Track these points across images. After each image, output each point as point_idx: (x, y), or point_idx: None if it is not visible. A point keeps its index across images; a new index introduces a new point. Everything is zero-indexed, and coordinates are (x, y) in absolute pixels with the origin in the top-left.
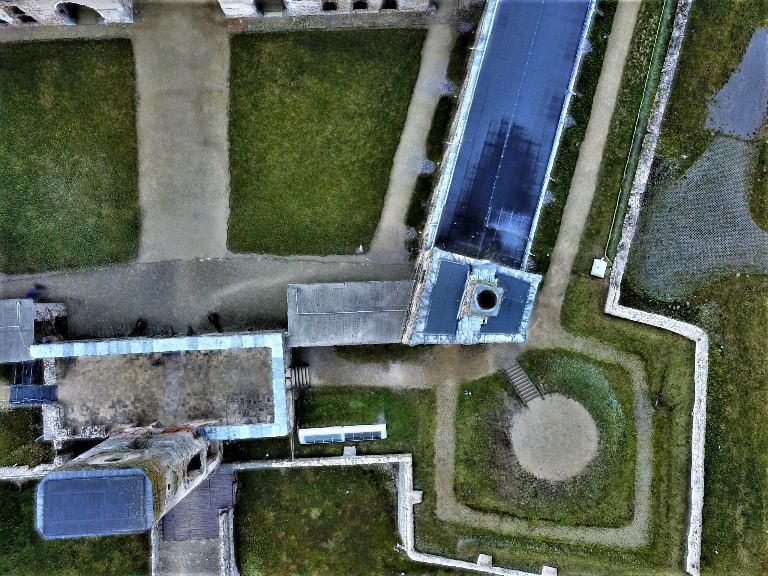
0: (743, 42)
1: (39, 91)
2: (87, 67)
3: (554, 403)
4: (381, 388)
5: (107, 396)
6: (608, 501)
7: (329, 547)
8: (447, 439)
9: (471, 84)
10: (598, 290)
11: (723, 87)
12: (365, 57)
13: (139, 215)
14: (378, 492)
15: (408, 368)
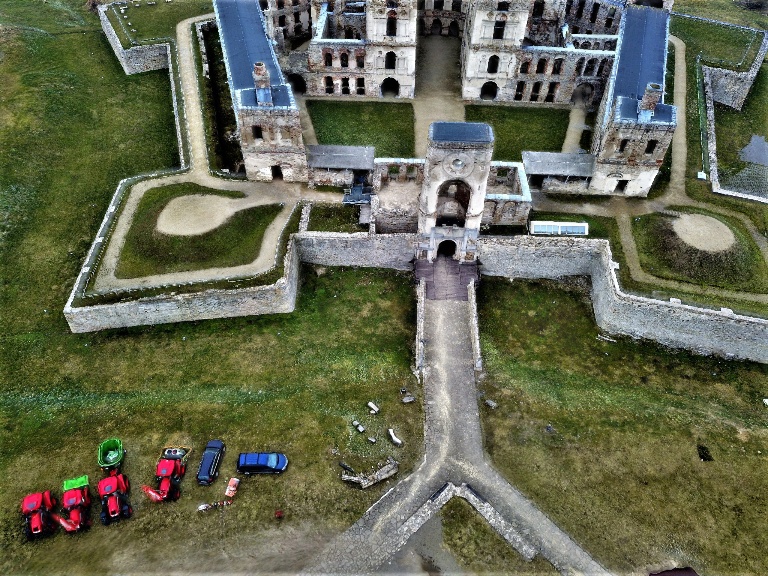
0: (748, 137)
1: (361, 115)
2: (388, 110)
3: (697, 217)
4: (579, 214)
5: (406, 200)
6: (754, 279)
7: (544, 334)
8: (629, 241)
9: (611, 87)
10: (705, 184)
11: (744, 148)
12: (539, 115)
13: (415, 157)
14: (577, 305)
15: (595, 207)
